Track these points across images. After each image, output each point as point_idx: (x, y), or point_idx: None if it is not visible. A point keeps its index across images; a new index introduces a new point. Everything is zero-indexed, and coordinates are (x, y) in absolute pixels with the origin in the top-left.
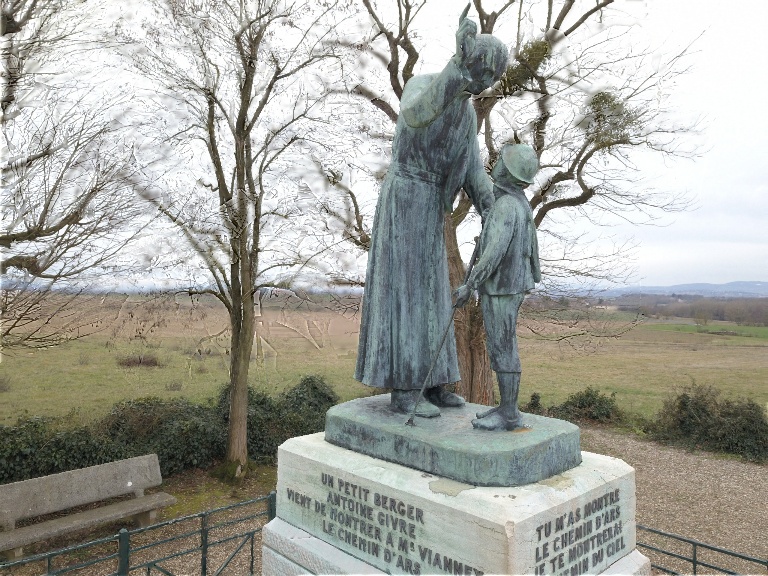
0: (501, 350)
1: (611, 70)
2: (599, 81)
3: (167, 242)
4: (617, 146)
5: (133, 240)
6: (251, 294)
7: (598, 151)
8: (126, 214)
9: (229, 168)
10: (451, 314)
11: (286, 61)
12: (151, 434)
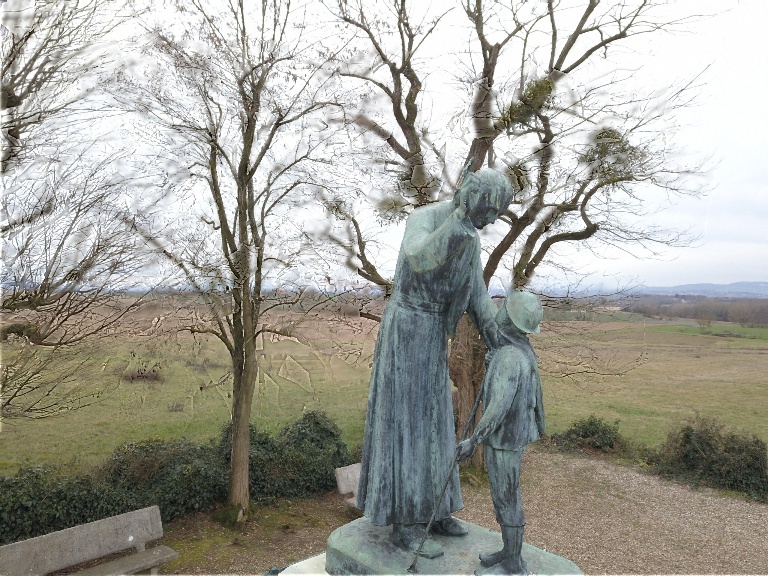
0: (505, 503)
1: (615, 112)
2: (603, 122)
3: (169, 301)
4: (621, 182)
5: (134, 307)
6: (253, 338)
7: (602, 187)
8: (128, 267)
9: (231, 206)
10: (454, 458)
11: (288, 107)
12: (153, 479)
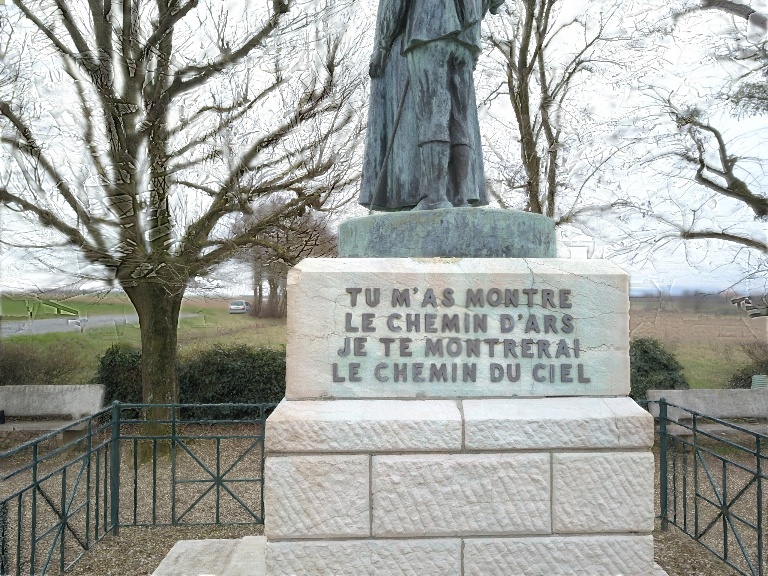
0: (419, 117)
1: None
2: None
3: None
4: None
5: None
6: None
7: None
8: None
9: None
10: None
11: None
12: None
